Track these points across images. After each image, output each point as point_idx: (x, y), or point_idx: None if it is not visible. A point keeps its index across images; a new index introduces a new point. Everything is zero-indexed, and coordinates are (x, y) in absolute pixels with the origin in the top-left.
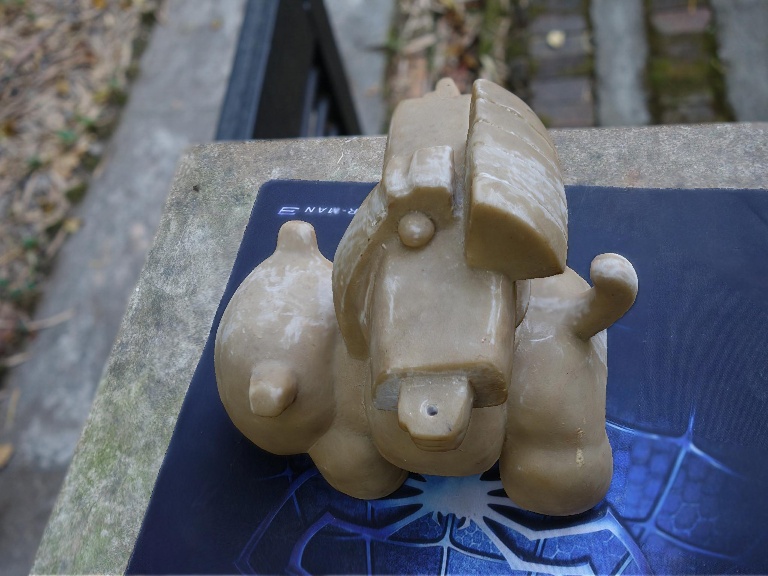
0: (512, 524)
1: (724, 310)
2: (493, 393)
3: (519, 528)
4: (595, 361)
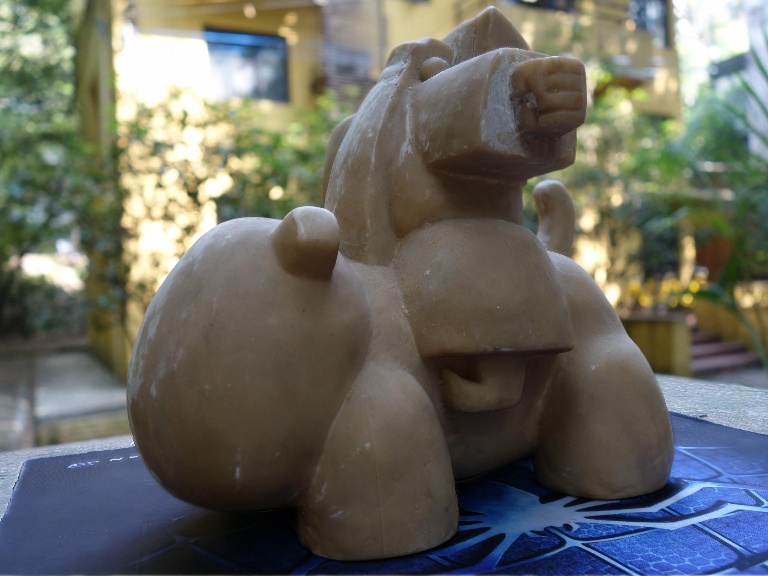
0: (621, 511)
1: None
2: None
3: (631, 510)
4: None
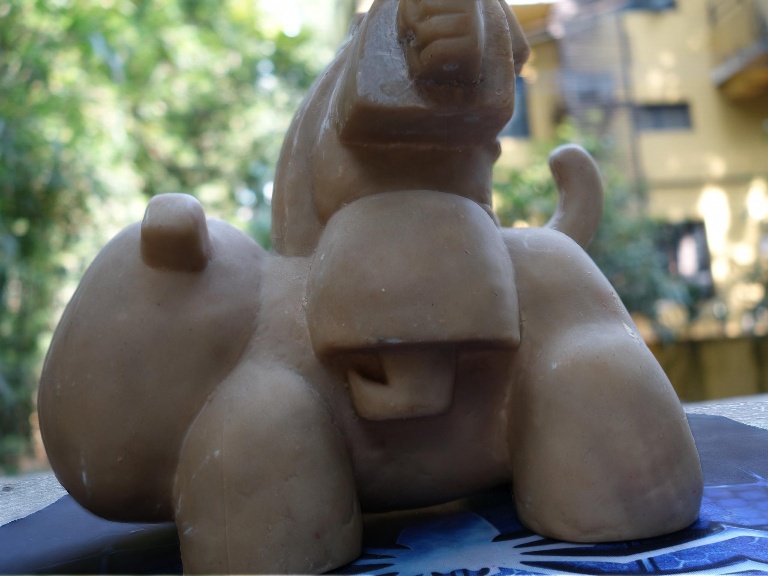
0: (578, 558)
1: (711, 441)
2: (499, 65)
3: (594, 558)
4: None
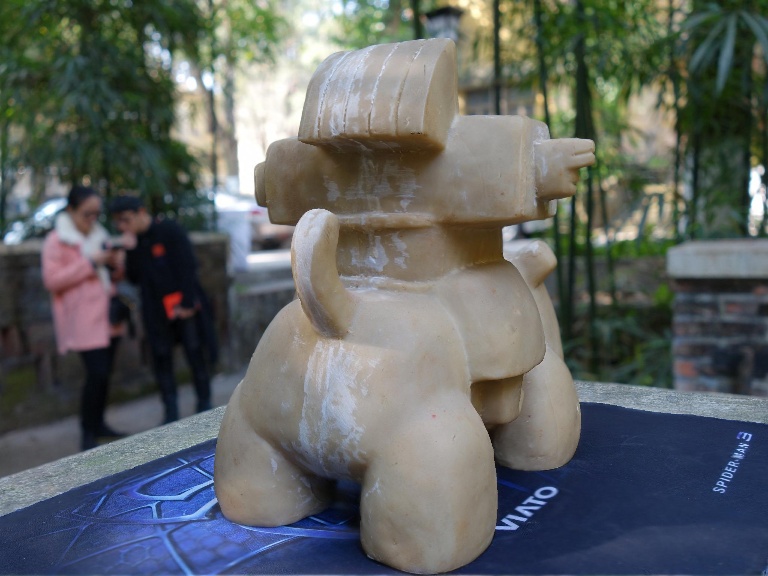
0: None
1: None
2: None
3: None
4: (299, 358)
